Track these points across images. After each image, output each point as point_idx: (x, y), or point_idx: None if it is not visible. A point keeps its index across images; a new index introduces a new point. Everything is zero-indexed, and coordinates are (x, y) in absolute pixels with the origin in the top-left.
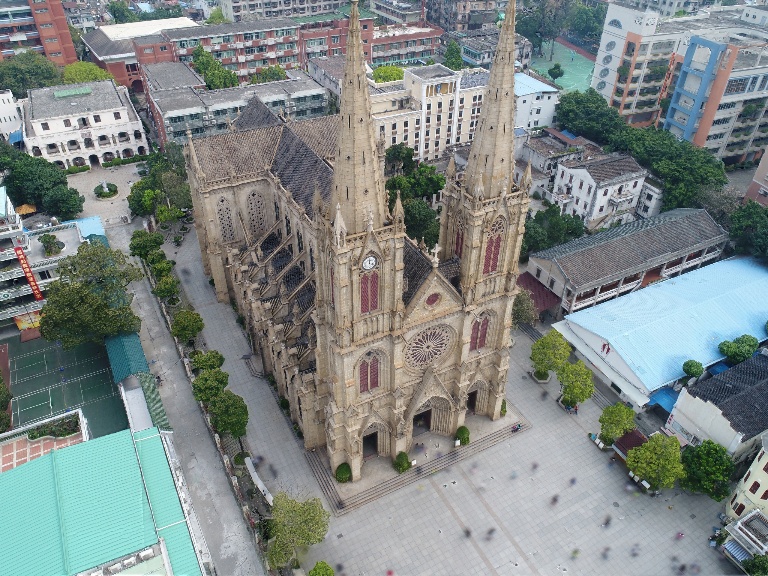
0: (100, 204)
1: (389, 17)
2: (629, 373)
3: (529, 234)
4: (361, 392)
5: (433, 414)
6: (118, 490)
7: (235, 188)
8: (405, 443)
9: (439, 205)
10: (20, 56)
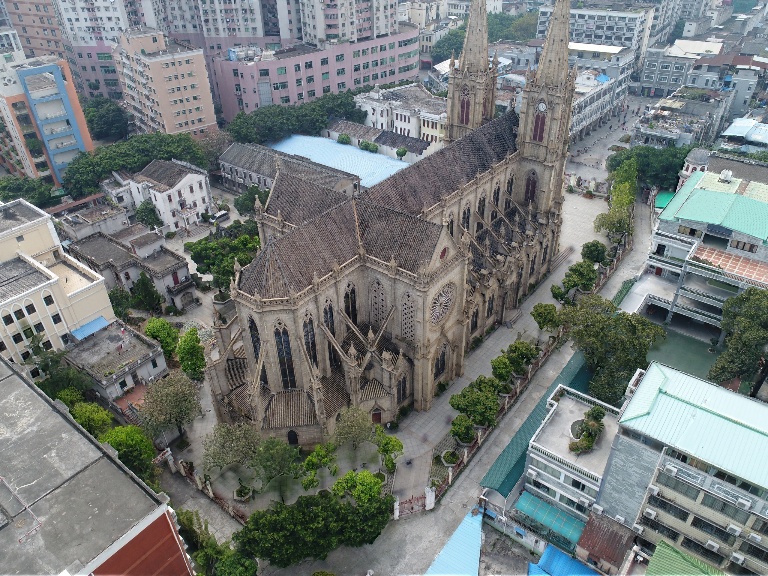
0: None
1: None
2: None
3: None
4: None
5: None
6: None
7: None
8: None
9: None
10: None
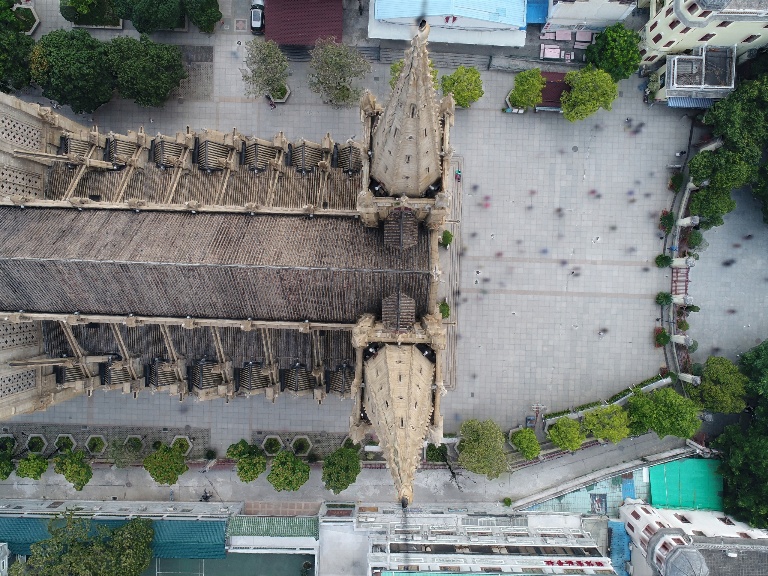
0: None
1: None
2: (491, 24)
3: None
4: None
5: None
6: None
7: None
8: None
9: None
10: None
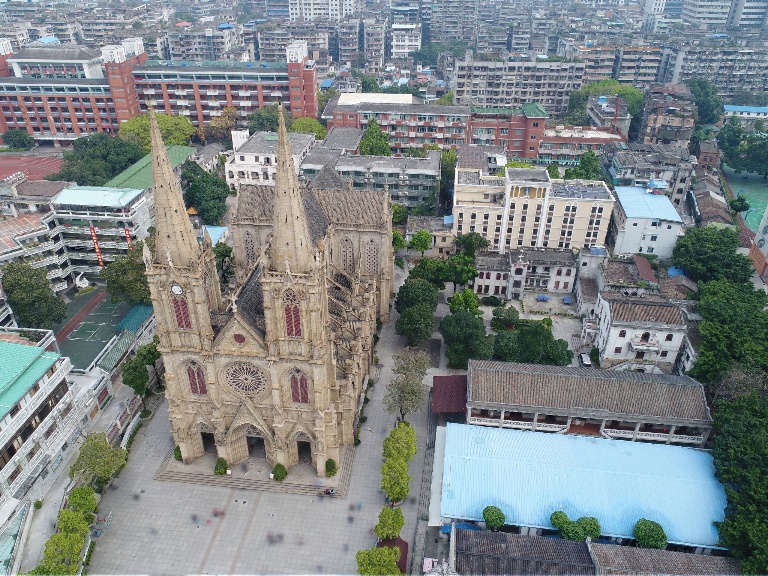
0: None
1: (594, 119)
2: None
3: (499, 344)
4: (193, 393)
5: (265, 443)
6: (1, 375)
7: (257, 227)
8: (231, 454)
9: (480, 297)
10: (269, 107)
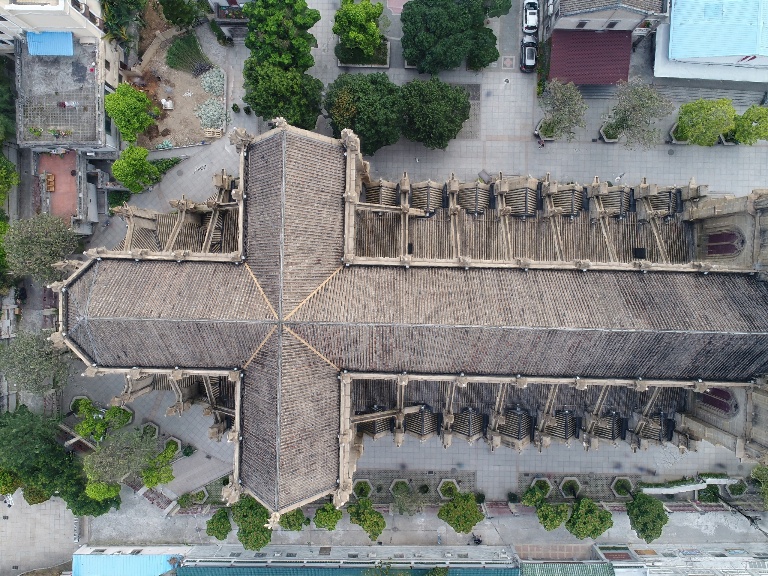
0: (0, 537)
1: None
2: None
3: None
4: None
5: None
6: None
7: None
8: None
9: None
10: None
